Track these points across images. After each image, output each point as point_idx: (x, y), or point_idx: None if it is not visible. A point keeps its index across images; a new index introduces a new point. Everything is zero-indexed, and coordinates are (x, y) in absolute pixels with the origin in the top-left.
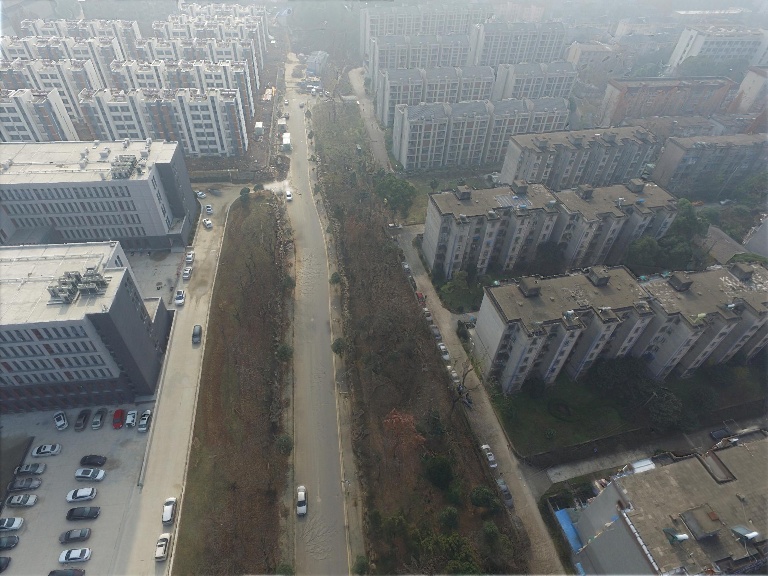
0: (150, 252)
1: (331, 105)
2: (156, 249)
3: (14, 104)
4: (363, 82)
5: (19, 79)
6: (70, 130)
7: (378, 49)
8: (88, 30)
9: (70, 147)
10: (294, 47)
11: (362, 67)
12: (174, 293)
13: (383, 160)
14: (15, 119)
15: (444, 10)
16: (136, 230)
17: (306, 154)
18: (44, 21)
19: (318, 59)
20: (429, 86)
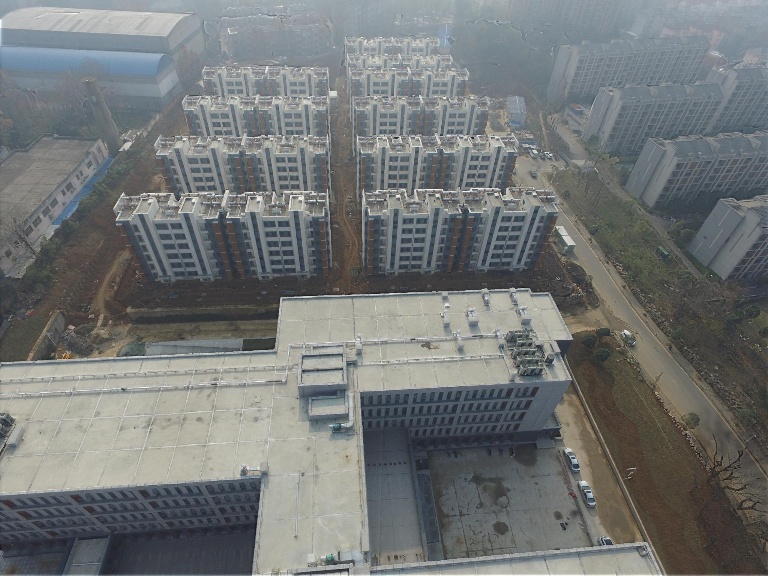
0: (512, 449)
1: (565, 173)
2: (517, 443)
3: (291, 218)
4: (573, 136)
5: (251, 163)
6: (330, 238)
7: (621, 104)
8: (278, 80)
9: (414, 304)
10: (473, 87)
11: (558, 114)
12: (590, 537)
13: (685, 264)
14: (283, 234)
15: (657, 46)
16: (506, 425)
17: (596, 259)
18: (226, 69)
19: (522, 108)
20: (719, 162)
